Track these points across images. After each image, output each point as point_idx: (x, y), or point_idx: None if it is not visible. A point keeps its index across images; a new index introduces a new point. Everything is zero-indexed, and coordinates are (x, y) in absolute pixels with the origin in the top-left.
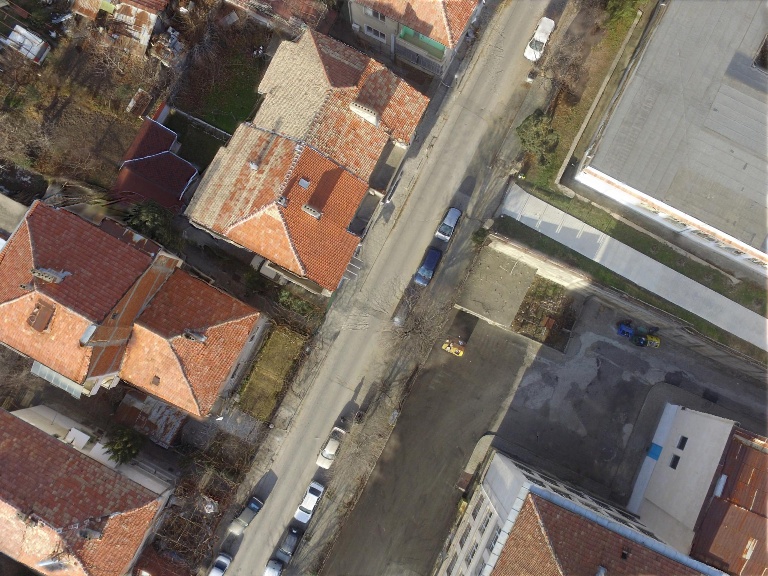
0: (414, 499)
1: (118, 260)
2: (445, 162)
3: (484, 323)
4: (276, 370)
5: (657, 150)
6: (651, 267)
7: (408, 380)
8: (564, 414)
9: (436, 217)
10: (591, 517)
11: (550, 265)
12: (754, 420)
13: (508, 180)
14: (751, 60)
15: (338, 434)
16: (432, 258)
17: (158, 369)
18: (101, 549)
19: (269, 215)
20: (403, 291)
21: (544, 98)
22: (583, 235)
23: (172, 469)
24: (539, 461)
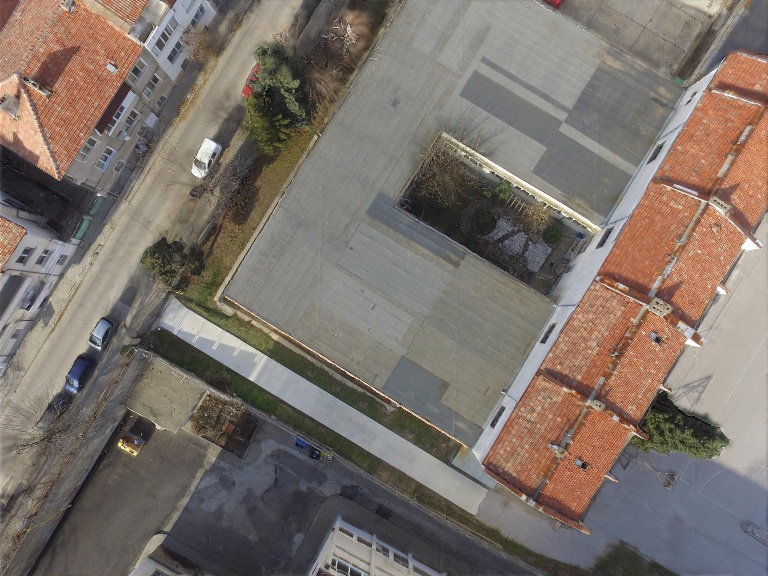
0: None
1: None
2: (109, 270)
3: None
4: None
5: (290, 284)
6: (307, 389)
7: (52, 484)
8: (237, 519)
9: (95, 324)
10: None
11: (198, 382)
12: (424, 540)
13: (167, 294)
14: (393, 201)
15: None
16: (78, 368)
17: None
18: None
19: None
20: (54, 396)
21: (208, 216)
22: (240, 353)
23: None
24: (207, 564)
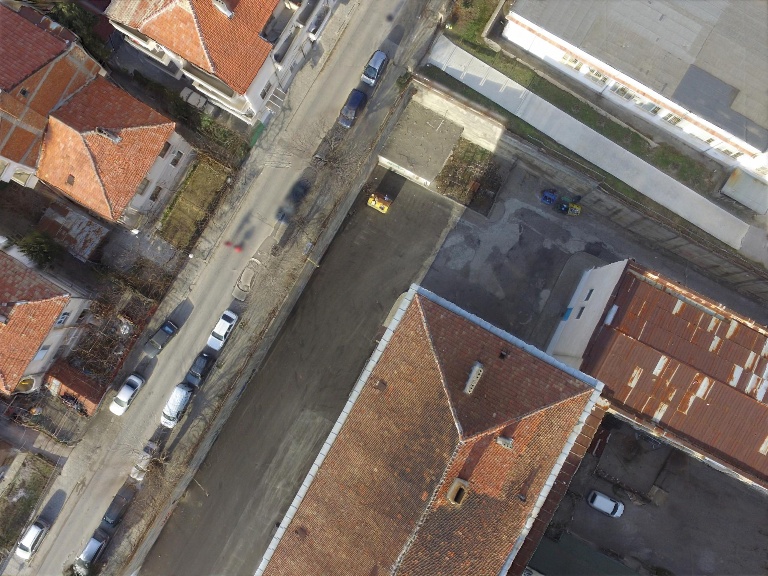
0: (332, 349)
1: (33, 42)
2: (376, 10)
3: (411, 184)
4: (199, 202)
5: None
6: (571, 125)
7: (326, 218)
8: (484, 276)
9: (364, 63)
10: (474, 321)
11: (471, 114)
12: None
13: (436, 30)
14: None
15: (253, 264)
16: (355, 98)
17: (72, 167)
18: (6, 334)
19: (180, 7)
20: (326, 131)
21: None
22: (506, 89)
23: (90, 286)
24: None
